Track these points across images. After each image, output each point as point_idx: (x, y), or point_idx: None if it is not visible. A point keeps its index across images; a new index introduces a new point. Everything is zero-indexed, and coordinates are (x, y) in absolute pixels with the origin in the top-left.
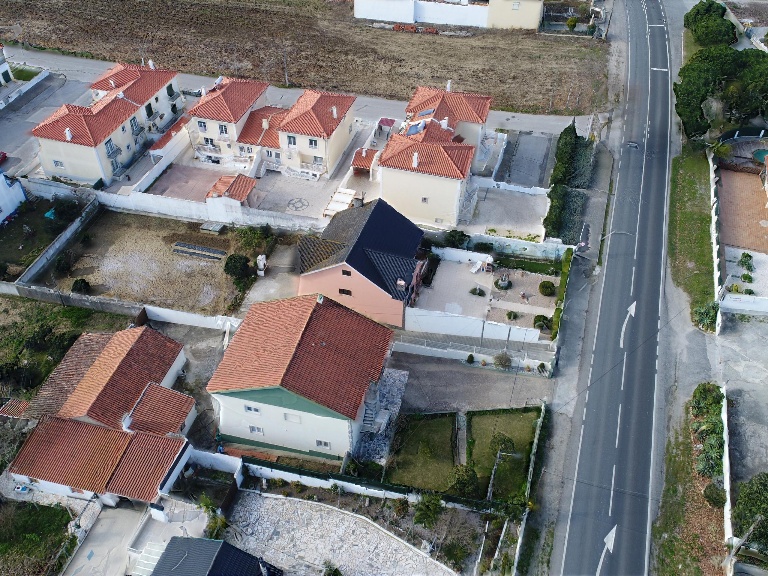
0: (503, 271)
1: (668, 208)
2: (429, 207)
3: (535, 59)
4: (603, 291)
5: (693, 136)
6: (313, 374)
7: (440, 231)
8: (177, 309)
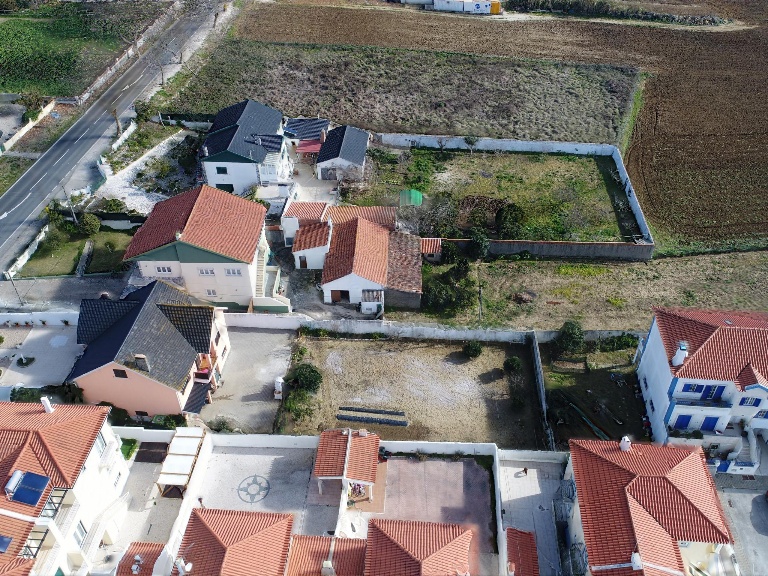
0: None
1: None
2: None
3: None
4: None
5: None
6: None
7: None
8: (360, 346)
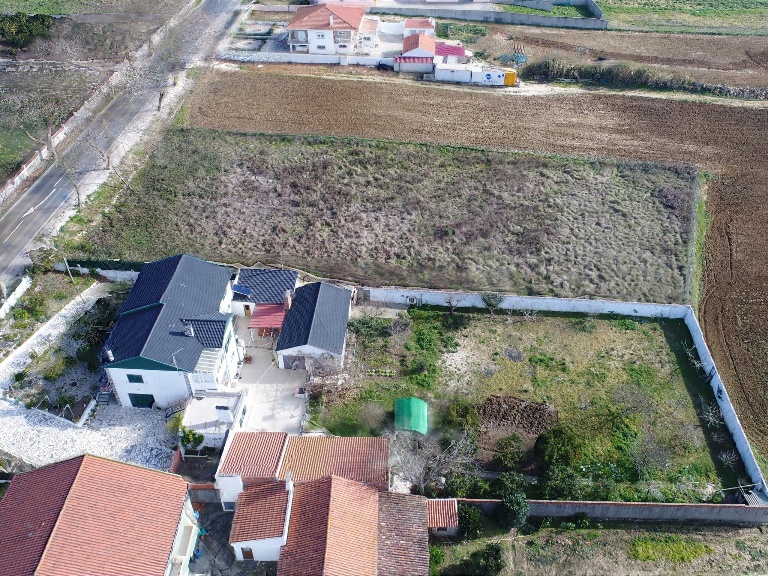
0: None
1: None
2: None
3: None
4: None
5: None
6: (50, 491)
7: None
8: None
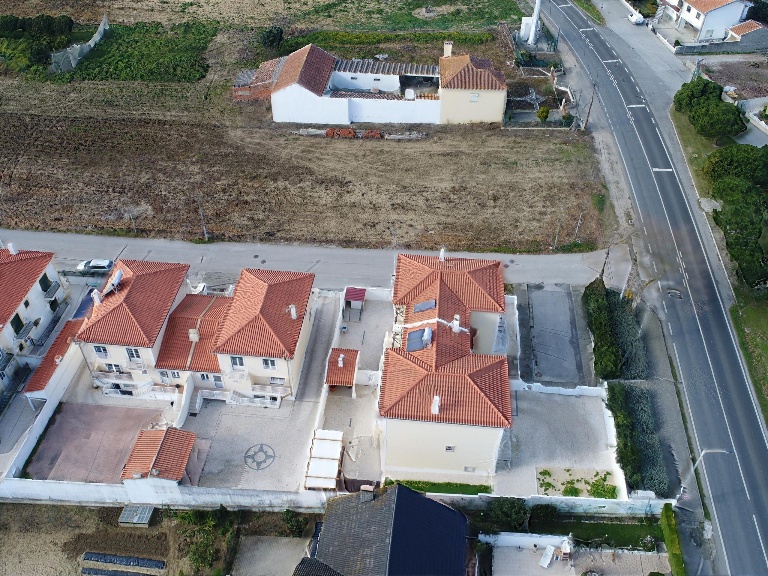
0: (584, 555)
1: (755, 396)
2: (456, 455)
3: (511, 167)
4: (730, 571)
5: (757, 284)
6: None
7: (482, 499)
8: None
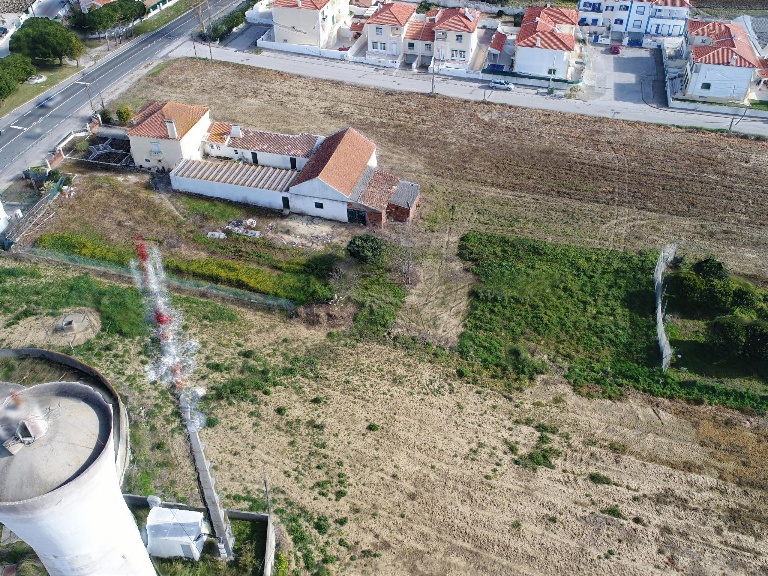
0: None
1: None
2: None
3: (189, 103)
4: None
5: None
6: None
7: None
8: None
